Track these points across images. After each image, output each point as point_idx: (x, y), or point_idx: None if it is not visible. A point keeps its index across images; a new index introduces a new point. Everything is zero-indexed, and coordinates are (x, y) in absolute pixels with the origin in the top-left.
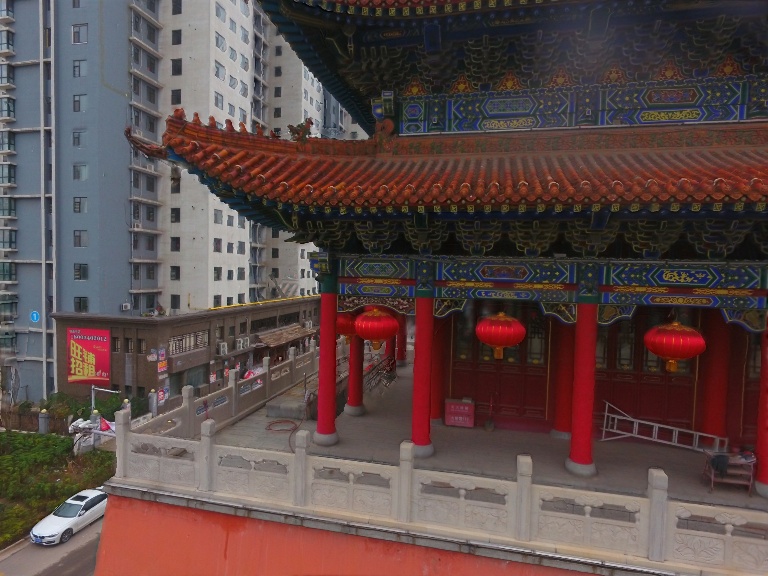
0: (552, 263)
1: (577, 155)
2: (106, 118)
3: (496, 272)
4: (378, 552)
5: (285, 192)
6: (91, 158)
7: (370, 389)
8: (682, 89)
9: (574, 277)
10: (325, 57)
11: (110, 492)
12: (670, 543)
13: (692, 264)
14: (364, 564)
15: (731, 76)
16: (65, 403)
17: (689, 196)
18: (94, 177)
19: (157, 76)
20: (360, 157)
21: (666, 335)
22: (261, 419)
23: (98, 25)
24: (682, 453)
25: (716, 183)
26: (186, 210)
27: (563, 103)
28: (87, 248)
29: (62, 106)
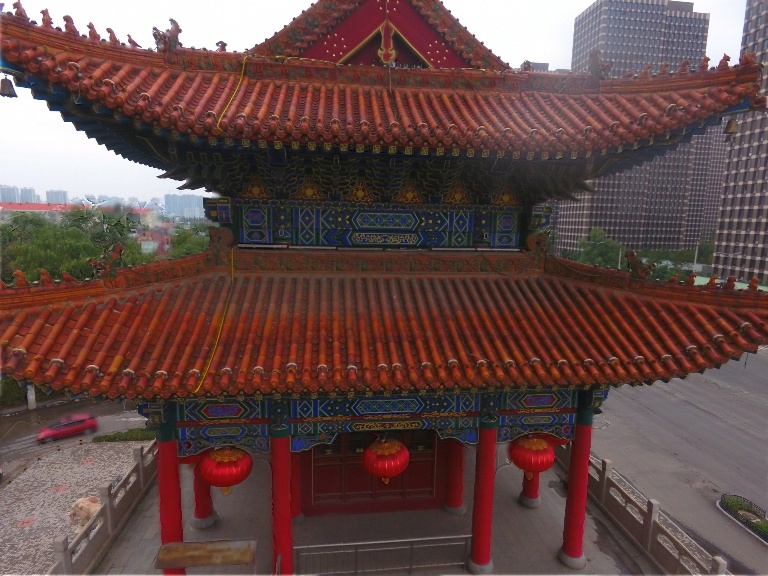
0: None
1: None
2: None
3: None
4: None
5: None
6: None
7: None
8: None
9: None
10: None
11: None
12: None
13: None
14: None
15: None
16: None
17: None
18: None
19: None
20: None
21: None
22: None
23: None
24: None
25: None
26: None
27: None
28: None
29: None
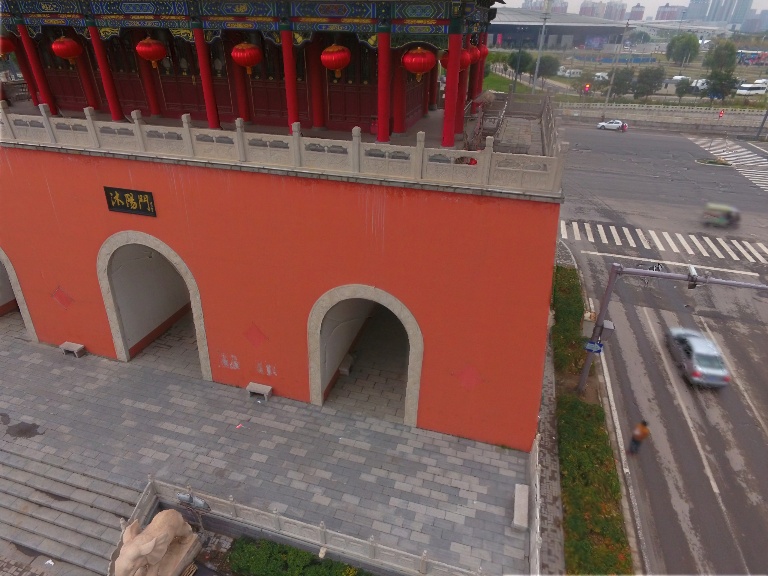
0: None
1: None
2: None
3: None
4: None
5: None
6: None
7: None
8: None
9: None
10: None
11: None
12: None
13: None
14: None
15: None
16: None
17: None
18: None
19: None
20: None
21: None
22: None
23: None
24: None
25: None
26: None
27: None
28: None
29: None
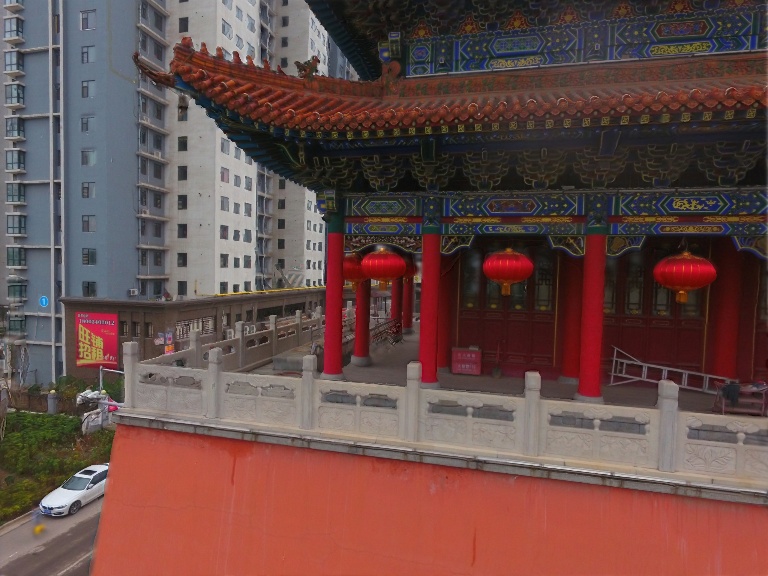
0: (560, 195)
1: (585, 90)
2: (114, 104)
3: (504, 206)
4: (385, 472)
5: (292, 118)
6: (99, 143)
7: (376, 343)
8: (692, 21)
9: (582, 208)
10: (332, 1)
11: (118, 422)
12: (681, 454)
13: (703, 191)
14: (371, 485)
15: (742, 7)
16: (73, 385)
17: (700, 104)
18: (102, 162)
19: (164, 64)
20: (367, 98)
21: (676, 264)
22: (268, 371)
23: (106, 11)
24: (692, 395)
25: (728, 92)
26: (193, 197)
27: (571, 40)
28: (95, 233)
29: (71, 92)
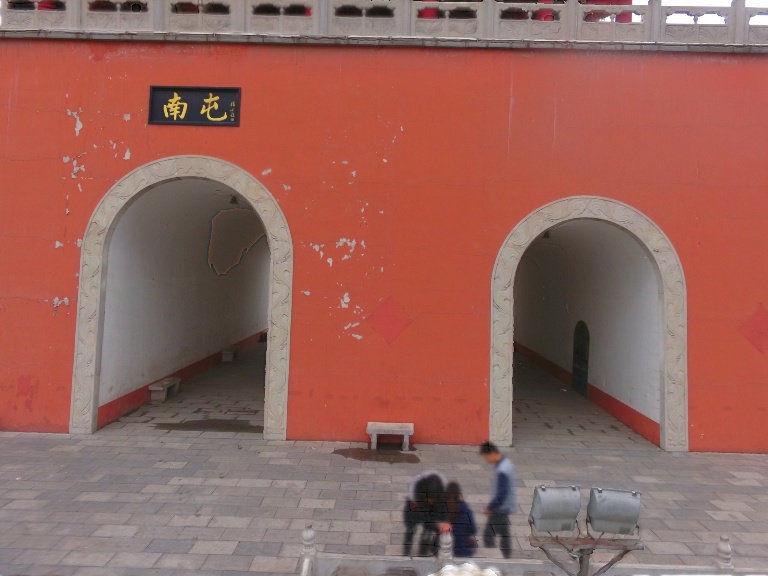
0: None
1: None
2: None
3: None
4: None
5: None
6: None
7: None
8: None
9: None
10: None
11: None
12: (3, 18)
13: None
14: None
15: None
16: None
17: None
18: None
19: None
20: None
21: None
22: None
23: None
24: None
25: None
26: None
27: None
28: None
29: None
